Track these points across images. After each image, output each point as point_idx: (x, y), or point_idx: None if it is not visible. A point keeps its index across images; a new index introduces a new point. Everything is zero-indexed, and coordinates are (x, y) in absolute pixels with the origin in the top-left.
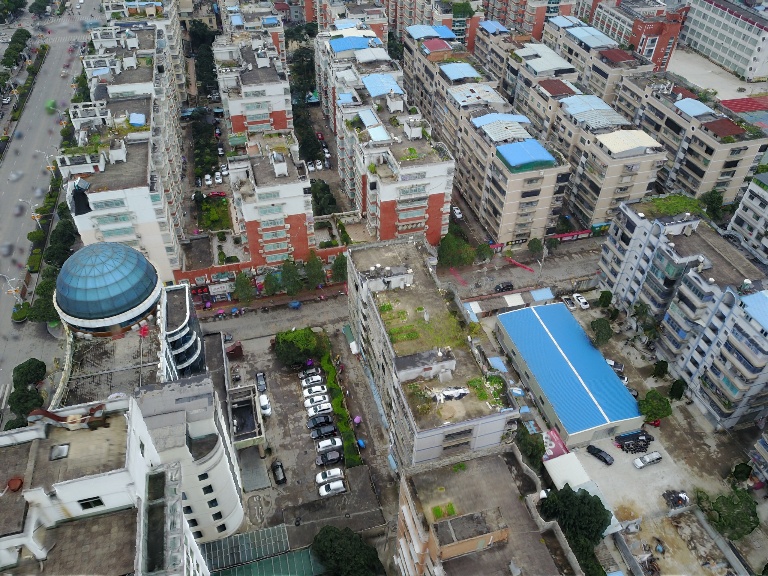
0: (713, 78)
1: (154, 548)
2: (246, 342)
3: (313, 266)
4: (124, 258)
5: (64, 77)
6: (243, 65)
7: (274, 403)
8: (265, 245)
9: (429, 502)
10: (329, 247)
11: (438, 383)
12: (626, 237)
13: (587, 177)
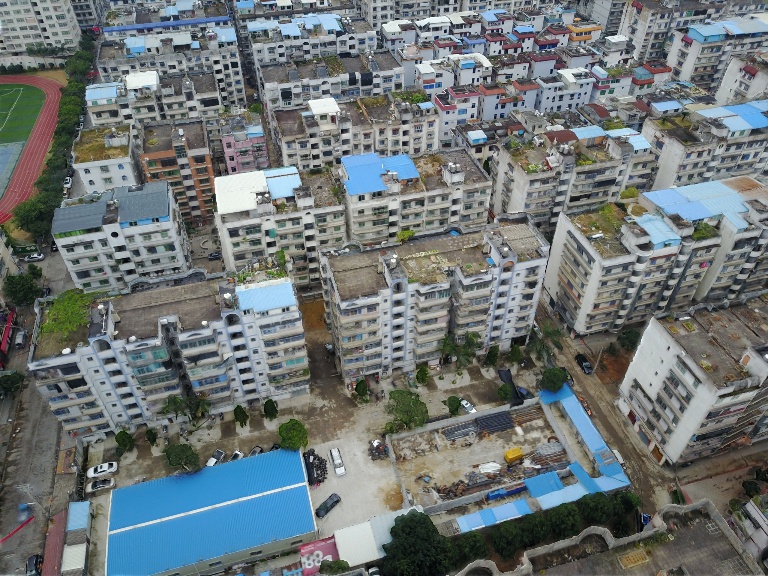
0: None
1: None
2: None
3: None
4: None
5: None
6: None
7: None
8: None
9: None
10: None
11: None
12: (77, 381)
13: None
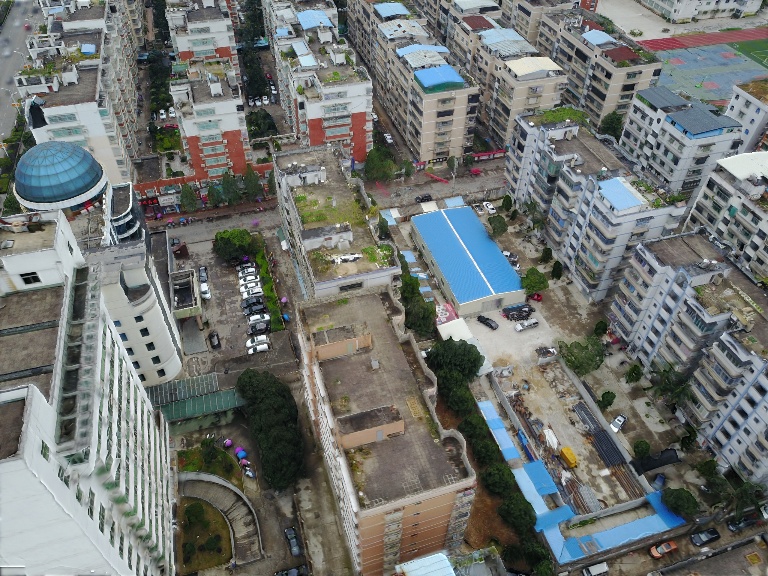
0: (642, 20)
1: (78, 309)
2: (192, 245)
3: (250, 178)
4: (72, 152)
5: (28, 27)
6: (190, 5)
7: (214, 290)
8: (206, 159)
9: (315, 325)
10: (265, 163)
11: (338, 251)
12: (521, 145)
13: (500, 101)
